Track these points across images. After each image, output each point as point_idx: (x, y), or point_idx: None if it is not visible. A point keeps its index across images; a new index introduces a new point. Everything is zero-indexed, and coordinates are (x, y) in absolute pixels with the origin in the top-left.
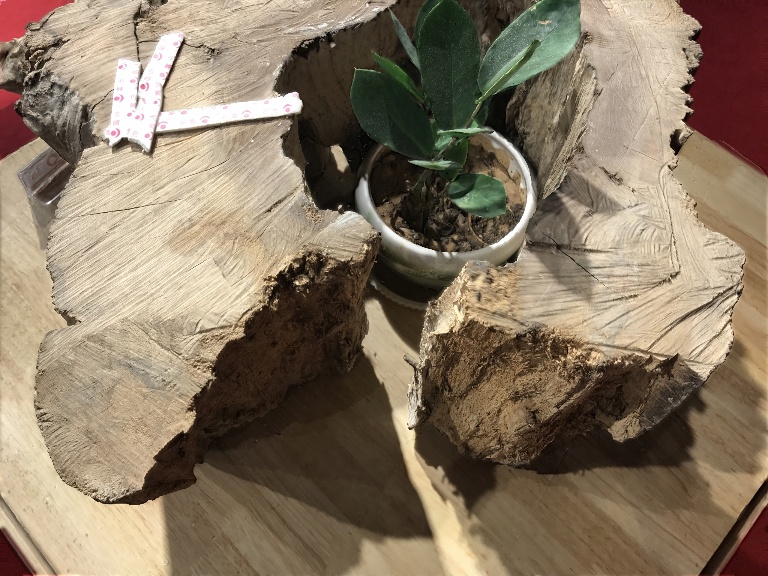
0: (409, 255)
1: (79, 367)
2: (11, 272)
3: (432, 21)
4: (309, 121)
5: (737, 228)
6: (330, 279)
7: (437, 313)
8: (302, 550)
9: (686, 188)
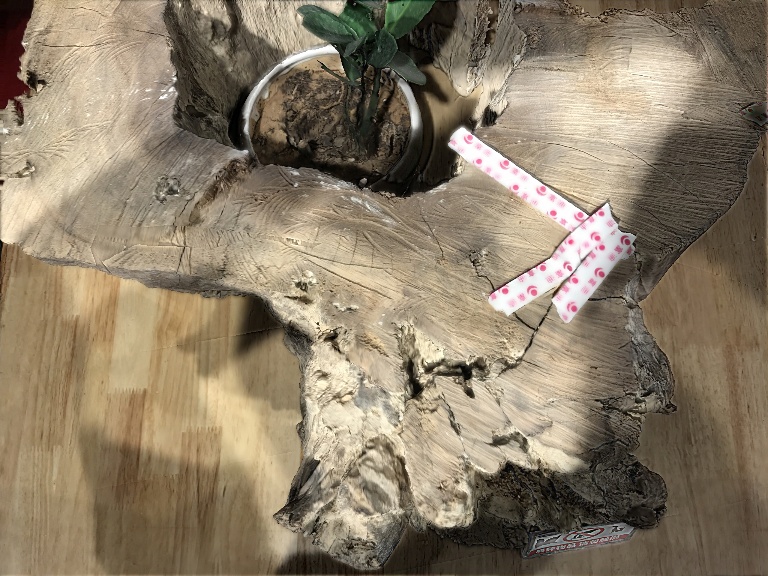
0: None
1: (767, 79)
2: (688, 460)
3: None
4: None
5: None
6: None
7: None
8: None
9: None
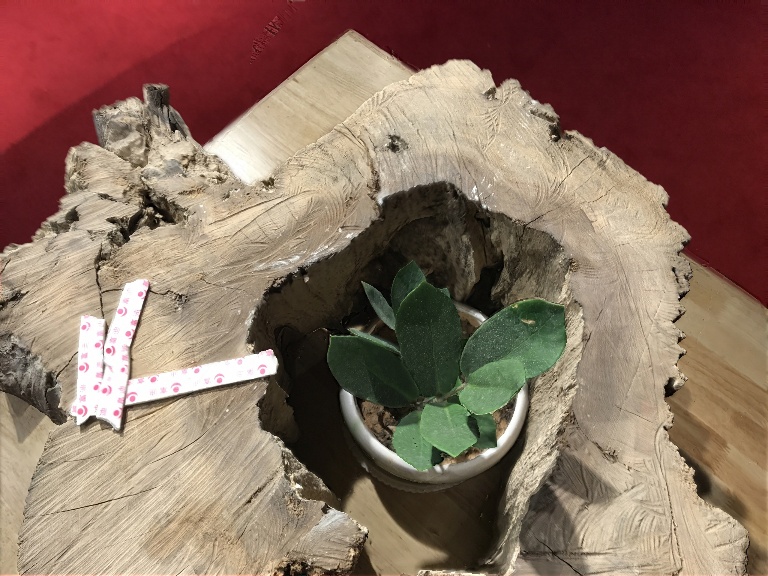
0: (399, 468)
1: None
2: None
3: (408, 304)
4: (287, 324)
5: (733, 371)
6: None
7: None
8: None
9: (679, 326)
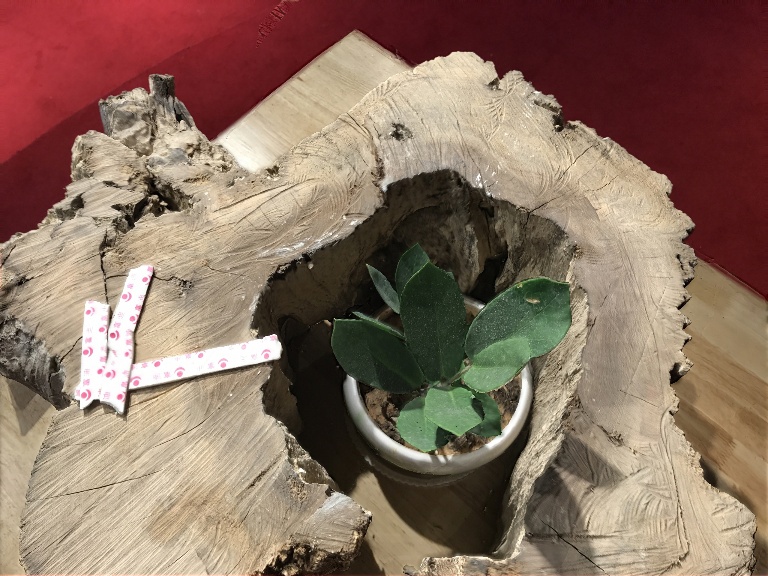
0: (403, 459)
1: None
2: None
3: (413, 286)
4: (291, 314)
5: (738, 366)
6: (320, 566)
7: (435, 573)
8: None
9: None
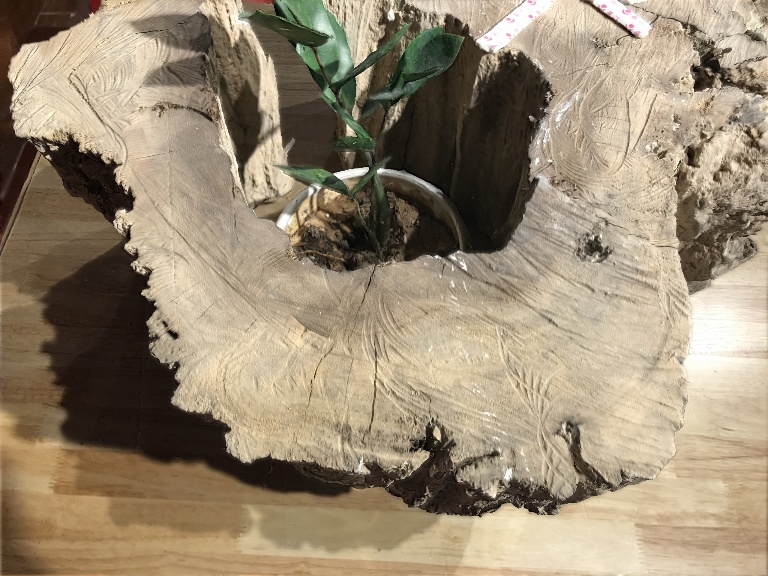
0: None
1: None
2: None
3: None
4: None
5: None
6: None
7: None
8: (284, 87)
9: None
